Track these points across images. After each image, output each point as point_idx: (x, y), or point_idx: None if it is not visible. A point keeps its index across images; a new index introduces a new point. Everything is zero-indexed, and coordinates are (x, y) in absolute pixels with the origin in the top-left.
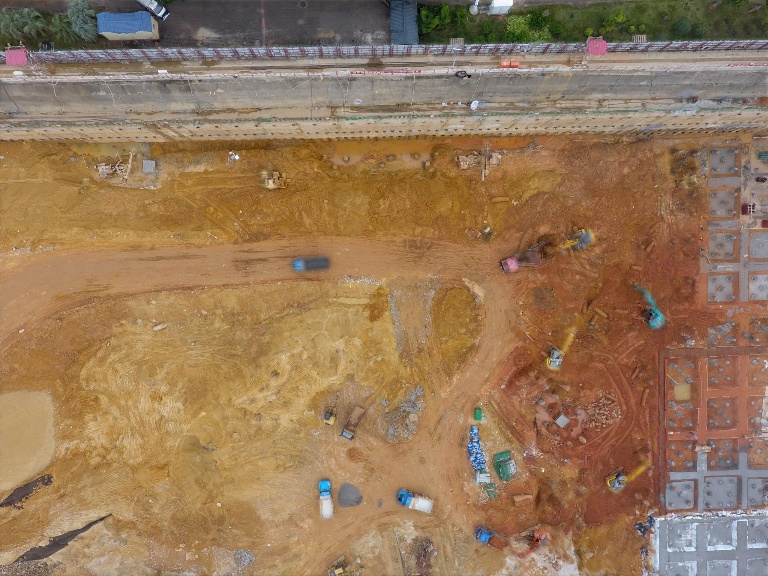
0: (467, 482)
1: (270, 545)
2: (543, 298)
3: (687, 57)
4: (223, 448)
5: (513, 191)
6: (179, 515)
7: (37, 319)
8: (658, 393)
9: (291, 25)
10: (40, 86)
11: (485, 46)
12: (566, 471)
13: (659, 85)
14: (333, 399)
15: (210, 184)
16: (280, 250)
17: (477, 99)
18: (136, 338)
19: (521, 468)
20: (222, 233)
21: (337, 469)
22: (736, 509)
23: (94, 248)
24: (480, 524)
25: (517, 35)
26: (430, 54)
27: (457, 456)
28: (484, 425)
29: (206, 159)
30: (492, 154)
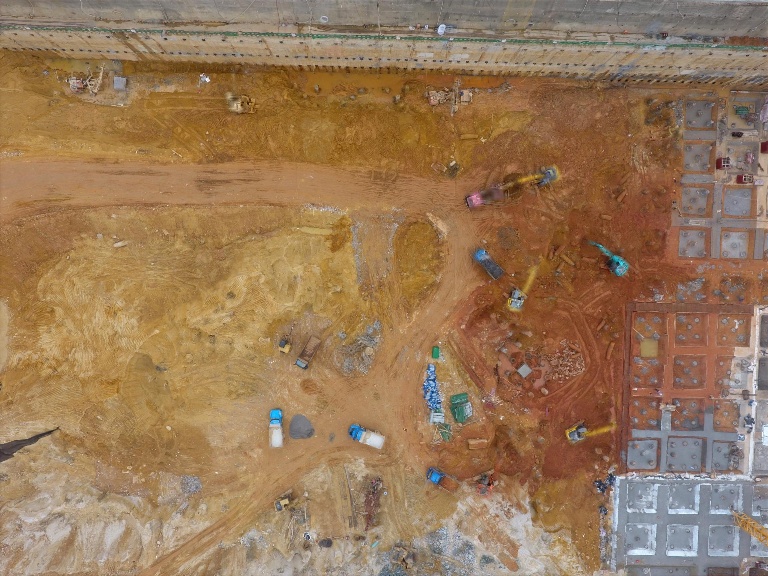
0: (421, 421)
1: (218, 473)
2: (507, 237)
3: None
4: (175, 368)
5: (482, 129)
6: (128, 436)
7: None
8: (624, 347)
9: None
10: None
11: None
12: (525, 420)
13: (626, 14)
14: (290, 328)
15: (179, 105)
16: (244, 173)
17: (444, 23)
18: (96, 253)
19: (478, 412)
20: (187, 152)
21: (290, 400)
22: (700, 472)
23: (58, 157)
24: (432, 465)
25: None
26: None
27: (412, 394)
28: (441, 364)
29: (177, 80)
30: (463, 91)
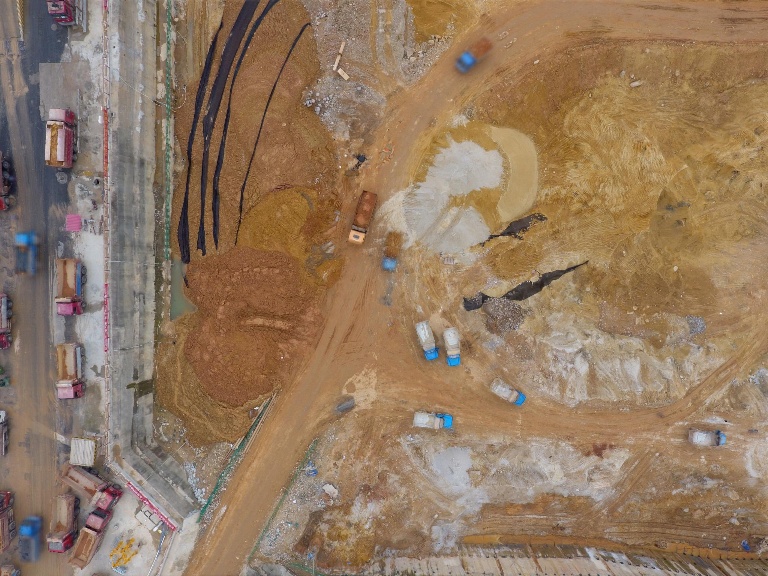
0: None
1: (722, 314)
2: None
3: None
4: (699, 204)
5: None
6: (639, 275)
7: (550, 52)
8: None
9: None
10: None
11: None
12: None
13: None
14: None
15: None
16: (765, 11)
17: None
18: (615, 92)
19: None
20: None
21: None
22: None
23: None
24: None
25: None
26: None
27: None
28: None
29: None
30: None
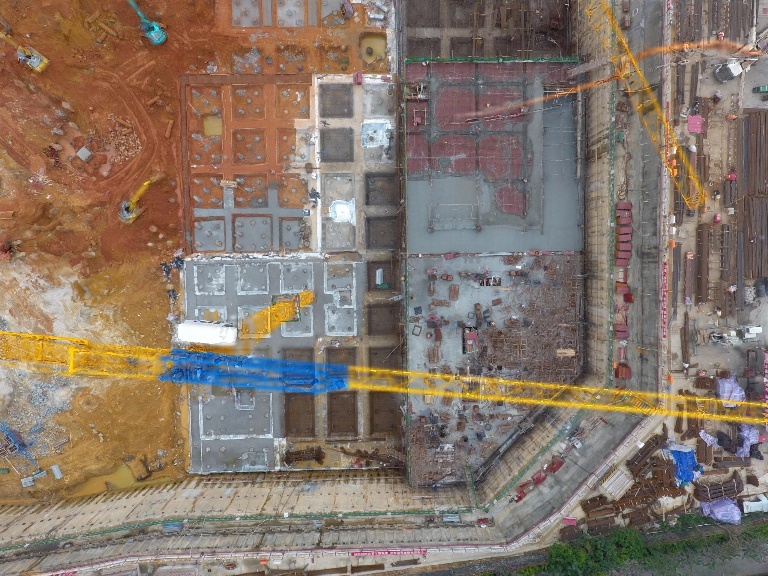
0: None
1: None
2: None
3: None
4: None
5: None
6: None
7: None
8: (180, 123)
9: None
10: None
11: None
12: (75, 200)
13: None
14: None
15: None
16: None
17: None
18: None
19: (8, 184)
20: None
21: None
22: (269, 251)
23: None
24: None
25: None
26: None
27: None
28: None
29: None
30: None
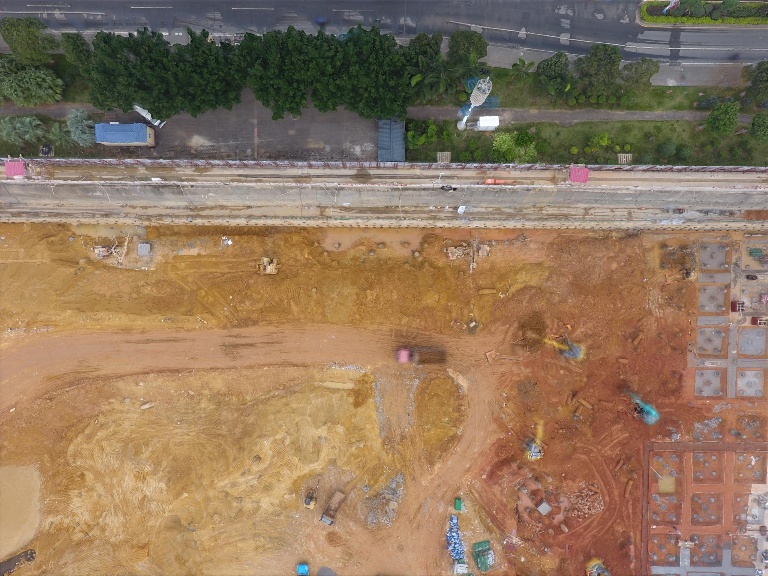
0: (445, 571)
1: None
2: (526, 392)
3: (672, 177)
4: (203, 529)
5: (500, 284)
6: None
7: (28, 399)
8: (642, 486)
9: (283, 135)
10: (39, 187)
11: (471, 161)
12: (546, 561)
13: (644, 200)
14: (314, 482)
15: (203, 268)
16: (268, 336)
17: (464, 205)
18: (124, 416)
19: (500, 558)
20: (212, 318)
21: (315, 552)
22: None
23: (86, 330)
24: None
25: (503, 152)
26: (417, 168)
27: (436, 544)
28: (464, 515)
29: (200, 243)
30: (481, 246)
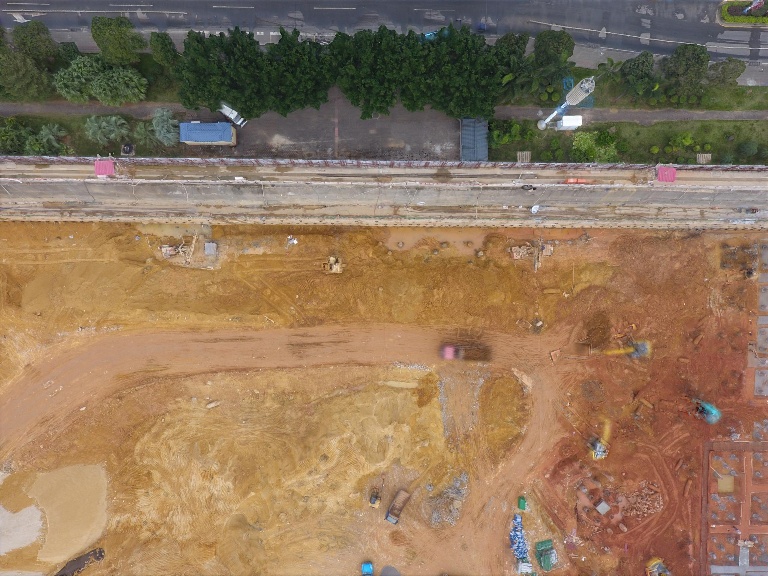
0: (508, 570)
1: None
2: (591, 391)
3: (751, 177)
4: (270, 528)
5: (564, 283)
6: None
7: (98, 397)
8: (701, 485)
9: (363, 135)
10: (120, 186)
11: (552, 161)
12: (606, 560)
13: (721, 200)
14: (378, 481)
15: (268, 267)
16: (334, 335)
17: (538, 204)
18: (190, 415)
19: (562, 558)
20: (278, 317)
21: (379, 551)
22: None
23: (156, 329)
24: None
25: (584, 152)
26: (498, 167)
27: (499, 544)
28: (527, 514)
29: (265, 242)
30: (545, 246)
